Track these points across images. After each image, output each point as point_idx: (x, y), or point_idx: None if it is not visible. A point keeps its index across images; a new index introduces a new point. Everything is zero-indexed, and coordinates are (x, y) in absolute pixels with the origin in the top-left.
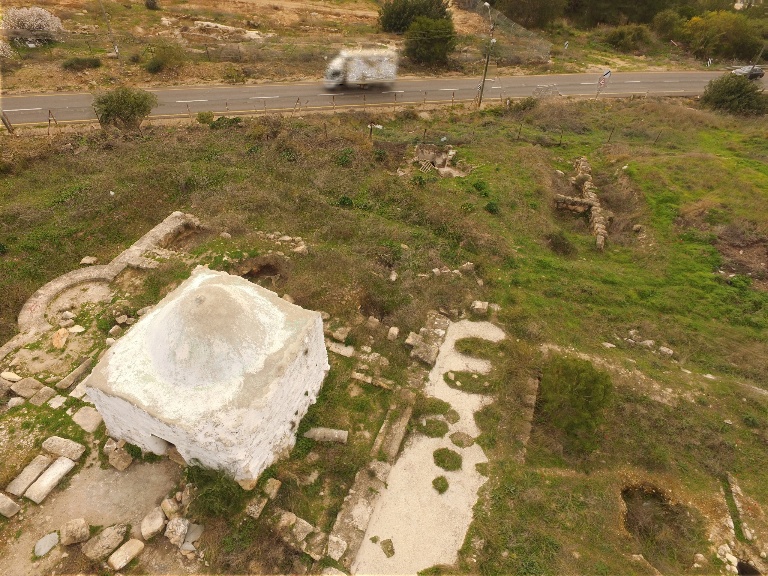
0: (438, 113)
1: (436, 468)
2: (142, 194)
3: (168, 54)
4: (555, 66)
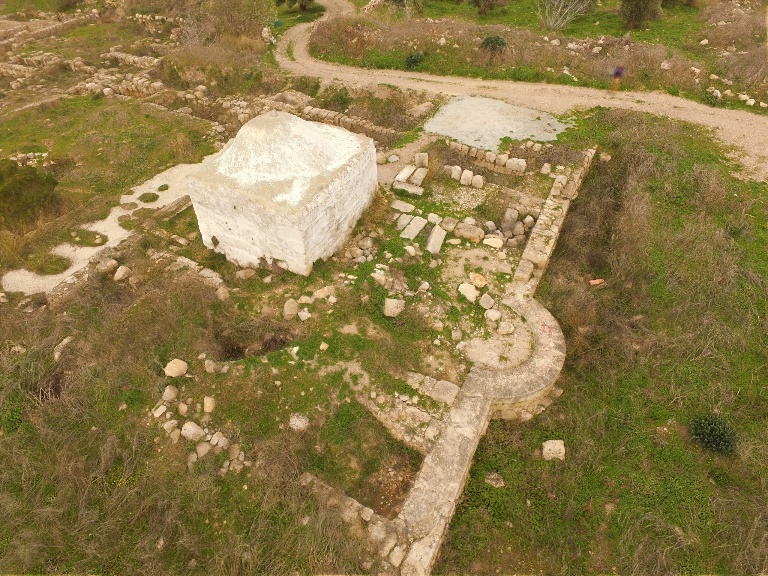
0: None
1: (160, 194)
2: None
3: None
4: None
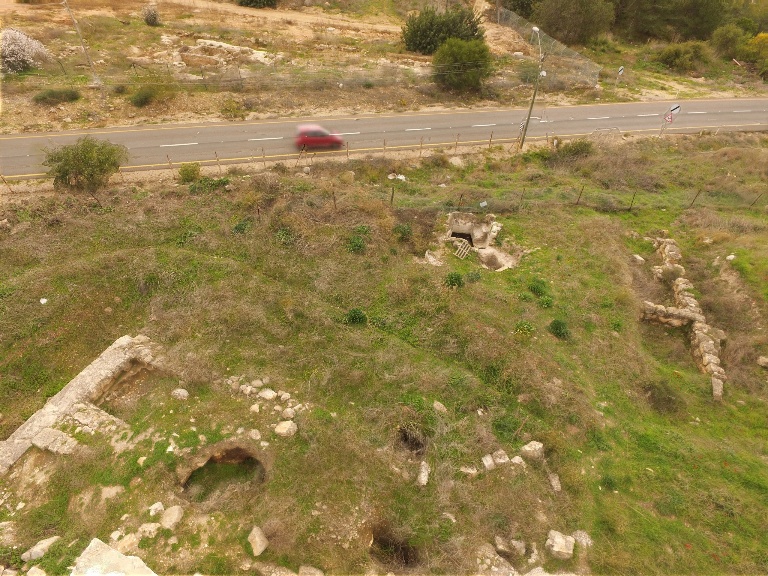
0: (472, 158)
1: None
2: (85, 300)
3: None
4: (605, 93)
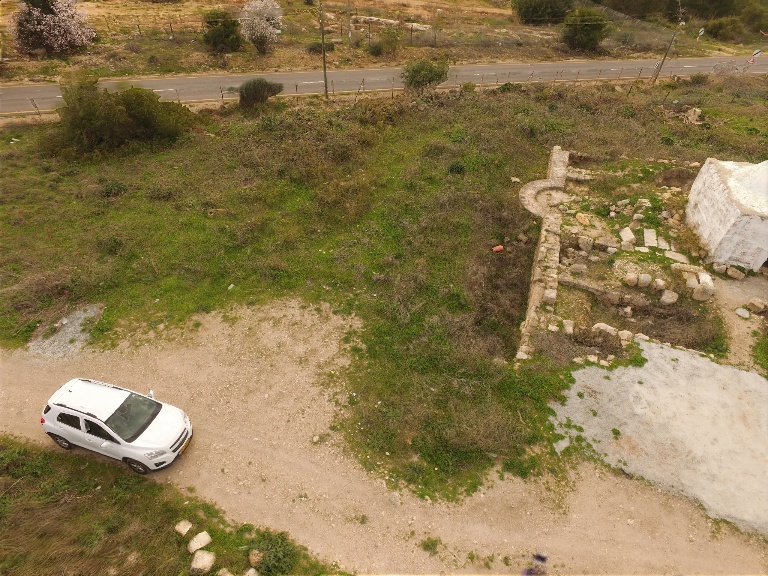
0: (627, 87)
1: None
2: None
3: (391, 39)
4: (682, 52)
